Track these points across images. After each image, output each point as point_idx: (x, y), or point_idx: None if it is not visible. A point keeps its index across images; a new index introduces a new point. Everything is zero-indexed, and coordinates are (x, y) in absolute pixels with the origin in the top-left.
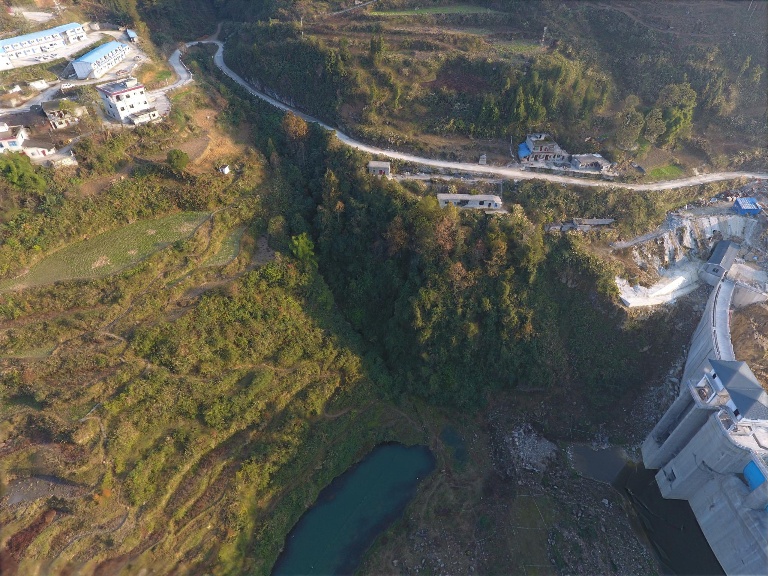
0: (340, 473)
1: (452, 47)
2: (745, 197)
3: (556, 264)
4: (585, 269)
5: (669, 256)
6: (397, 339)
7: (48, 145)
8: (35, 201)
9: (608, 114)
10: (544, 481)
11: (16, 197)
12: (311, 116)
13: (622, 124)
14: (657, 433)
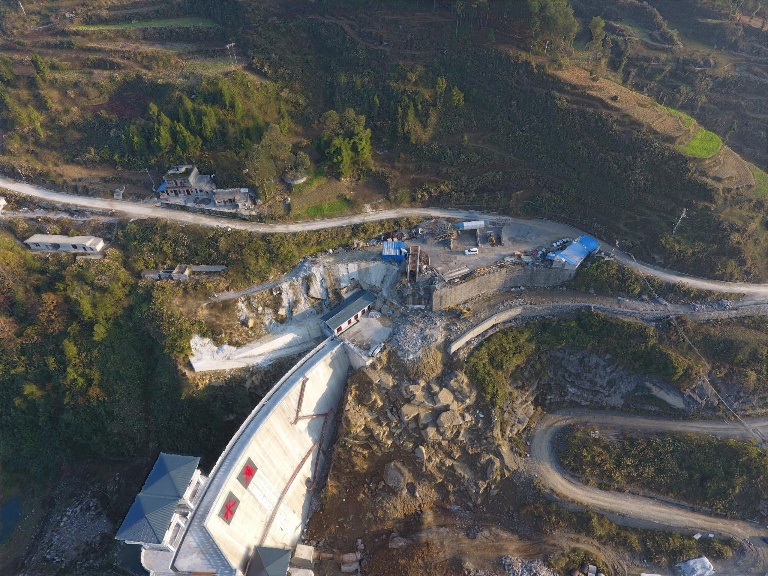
0: None
1: (137, 65)
2: (412, 238)
3: (134, 319)
4: (158, 326)
5: (288, 308)
6: None
7: None
8: None
9: (292, 141)
10: (59, 573)
11: None
12: None
13: None
14: None
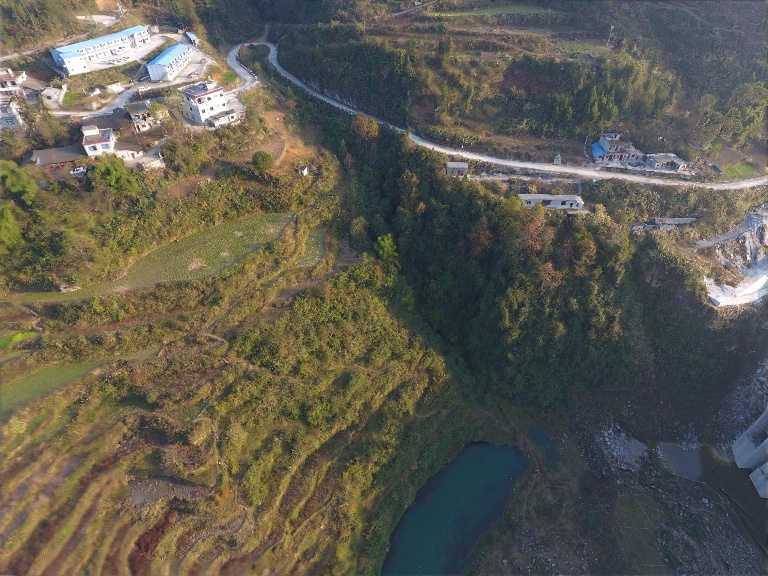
0: (434, 473)
1: (517, 47)
2: None
3: (642, 264)
4: (673, 268)
5: (750, 255)
6: (480, 339)
7: (137, 148)
8: (129, 203)
9: (676, 113)
10: (641, 481)
11: (112, 200)
12: (376, 117)
13: (701, 123)
14: (752, 432)
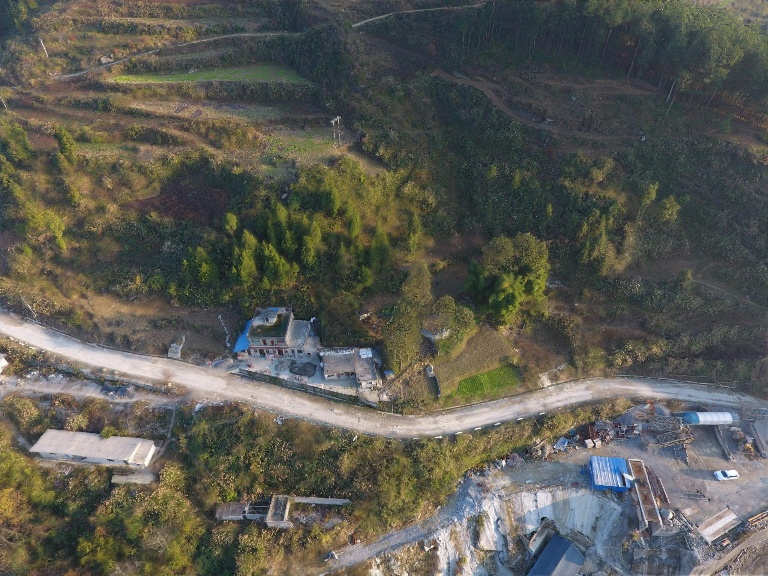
0: None
1: (200, 140)
2: (620, 438)
3: None
4: None
5: (447, 572)
6: None
7: None
8: None
9: None
10: None
11: None
12: None
13: None
14: None
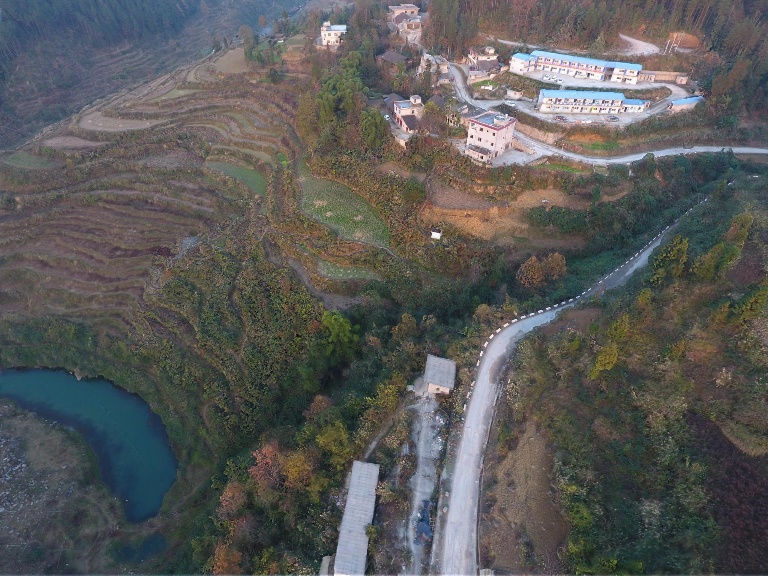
0: None
1: None
2: None
3: None
4: None
5: None
6: None
7: (413, 126)
8: None
9: None
10: None
11: None
12: None
13: None
14: None
